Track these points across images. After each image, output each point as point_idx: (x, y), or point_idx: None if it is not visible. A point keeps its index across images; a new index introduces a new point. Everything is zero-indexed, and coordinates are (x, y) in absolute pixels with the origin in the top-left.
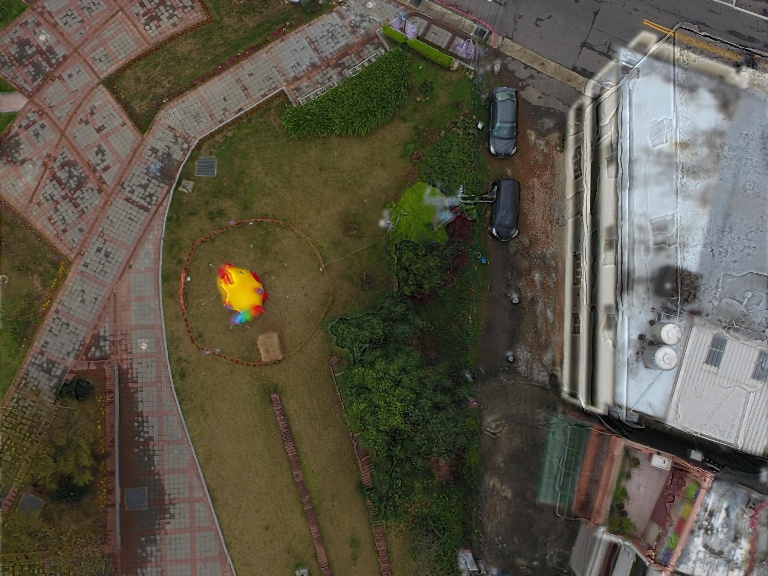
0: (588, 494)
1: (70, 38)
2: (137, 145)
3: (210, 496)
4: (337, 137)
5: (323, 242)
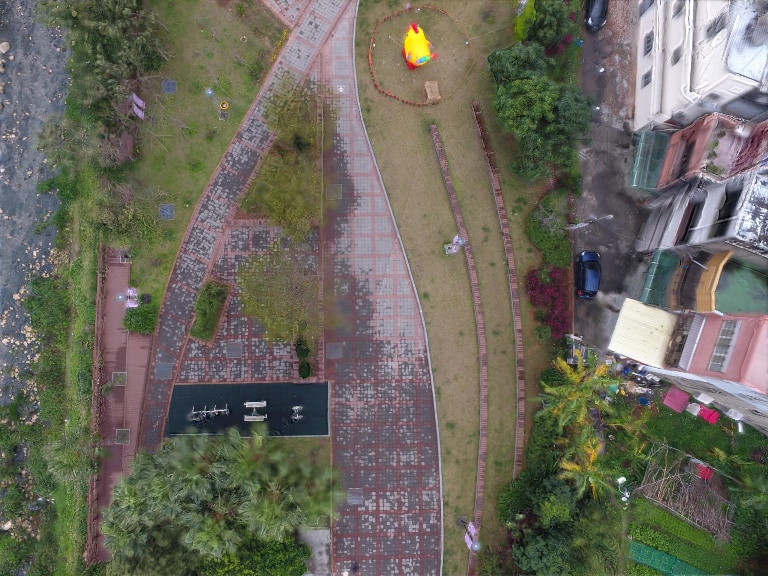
0: (655, 173)
1: None
2: None
3: (386, 191)
4: None
5: (469, 24)
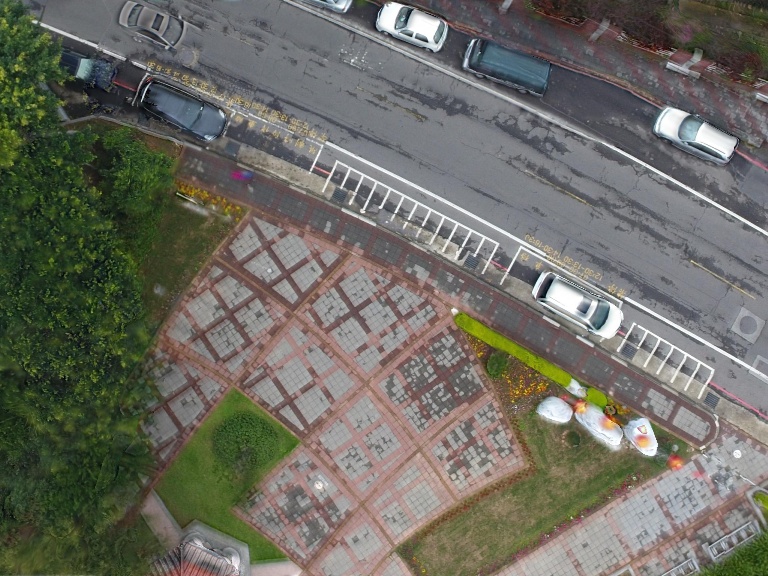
0: None
1: (355, 488)
2: None
3: None
4: None
5: None
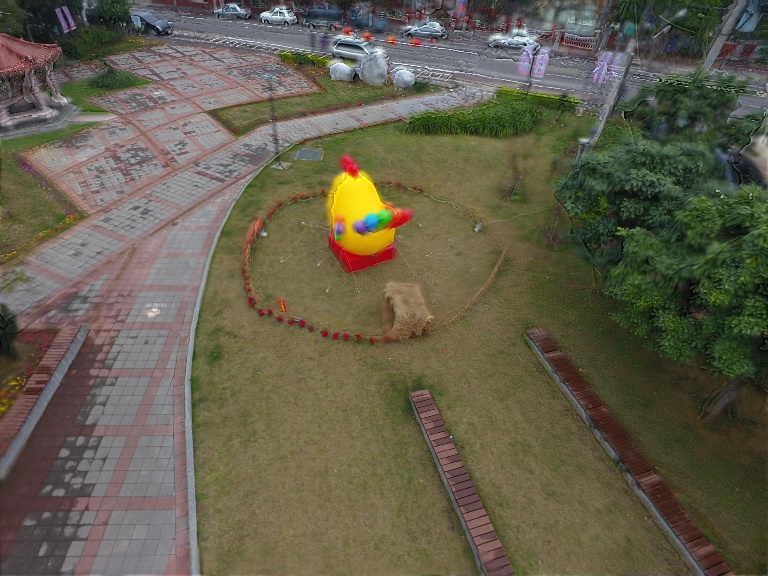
0: None
1: (185, 94)
2: (228, 142)
3: None
4: (472, 135)
5: (473, 206)
